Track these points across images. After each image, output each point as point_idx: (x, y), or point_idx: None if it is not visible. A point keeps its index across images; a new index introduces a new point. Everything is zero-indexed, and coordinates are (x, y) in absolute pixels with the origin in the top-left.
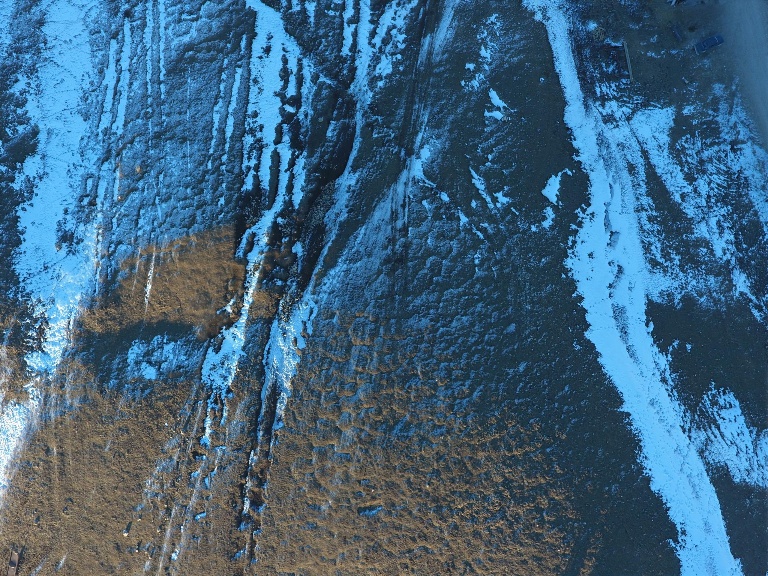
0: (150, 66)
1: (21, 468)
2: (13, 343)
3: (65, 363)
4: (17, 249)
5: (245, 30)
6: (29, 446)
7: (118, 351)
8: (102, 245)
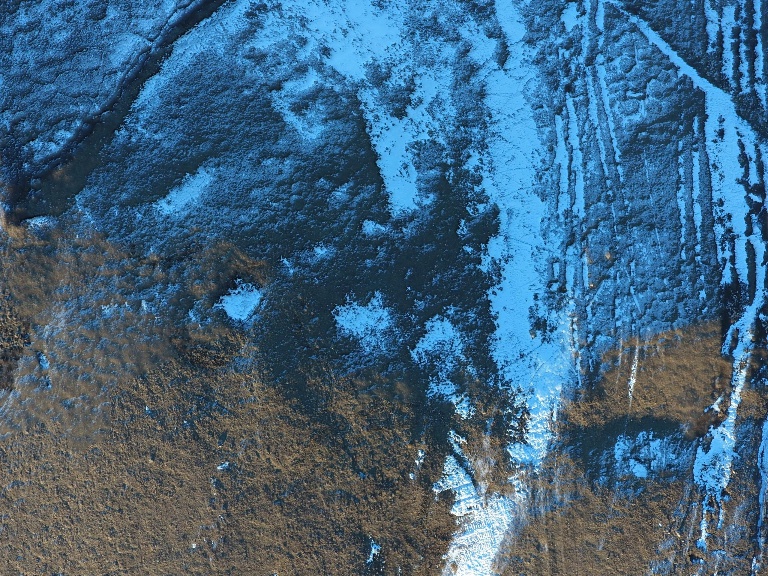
0: (602, 146)
1: (512, 563)
2: (497, 433)
3: (552, 457)
4: (492, 335)
5: (697, 112)
6: (520, 541)
7: (604, 446)
8: (579, 335)
